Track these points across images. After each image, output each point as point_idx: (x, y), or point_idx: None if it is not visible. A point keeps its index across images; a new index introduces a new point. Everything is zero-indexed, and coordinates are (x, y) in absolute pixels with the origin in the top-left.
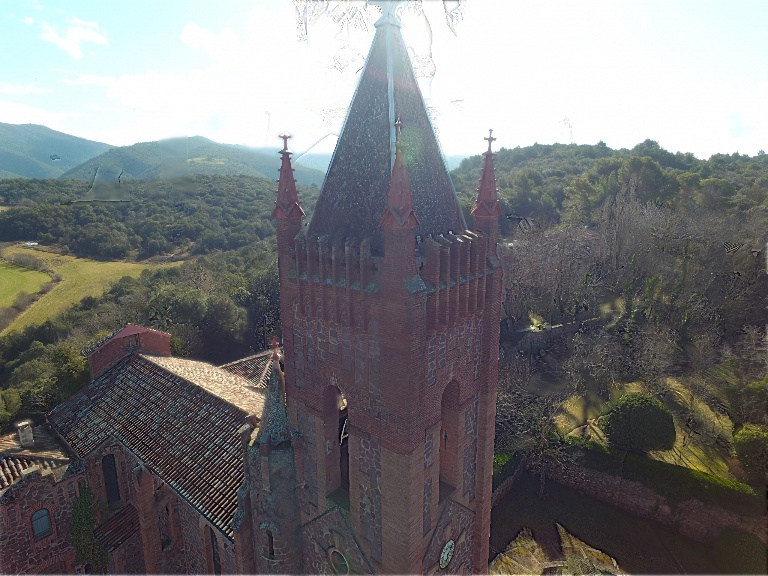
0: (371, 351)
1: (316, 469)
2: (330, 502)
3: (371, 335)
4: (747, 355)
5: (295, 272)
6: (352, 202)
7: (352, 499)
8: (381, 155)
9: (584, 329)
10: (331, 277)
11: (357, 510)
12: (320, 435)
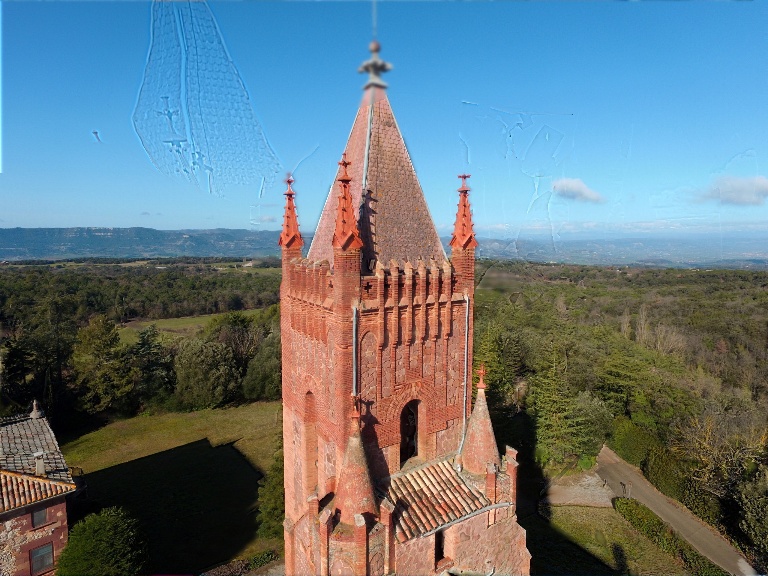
0: None
1: None
2: None
3: None
4: None
5: None
6: None
7: None
8: None
9: None
10: None
11: None
12: None
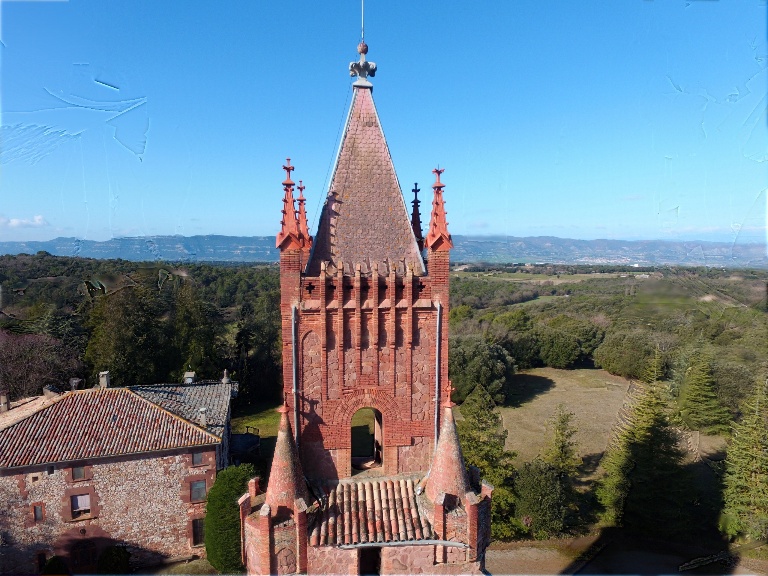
0: None
1: None
2: None
3: None
4: None
5: None
6: None
7: None
8: None
9: None
10: None
11: None
12: None
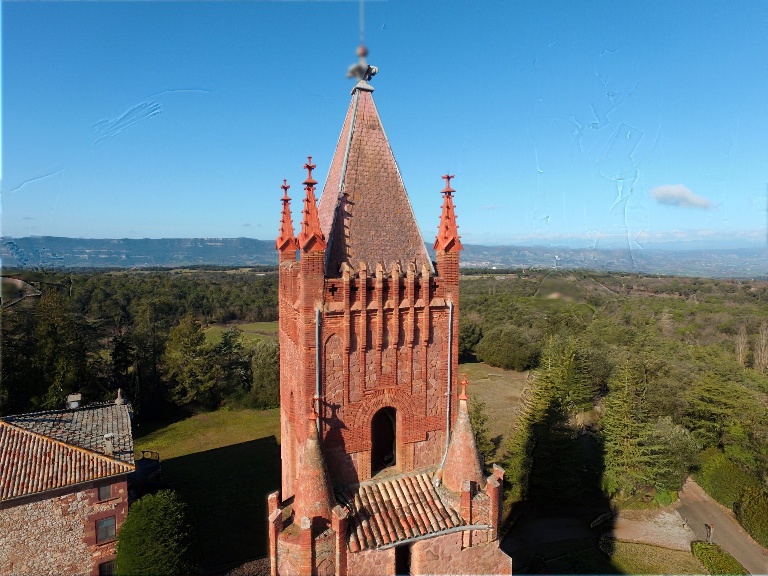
0: None
1: None
2: None
3: None
4: None
5: None
6: None
7: None
8: None
9: None
10: None
11: None
12: None
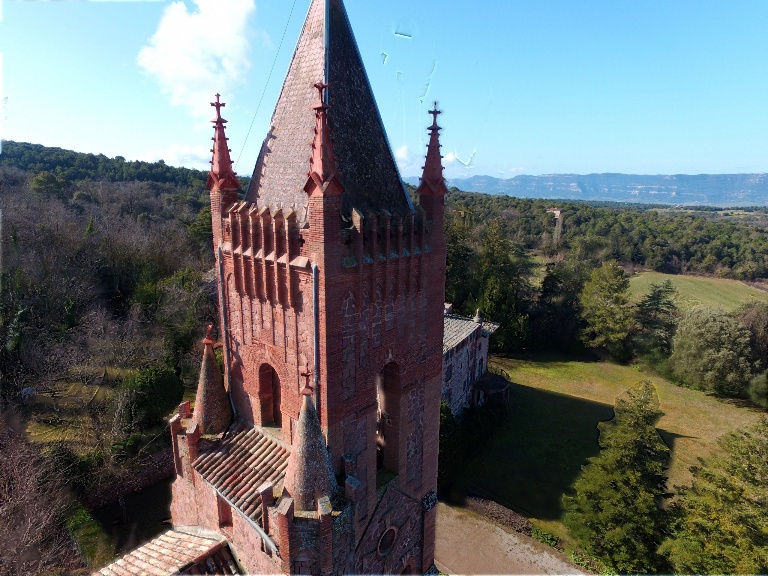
0: (420, 305)
1: (366, 474)
2: (381, 490)
3: (421, 291)
4: (178, 307)
5: (352, 259)
6: (364, 174)
7: (401, 459)
8: (375, 129)
9: (1, 347)
10: (392, 251)
11: (405, 463)
12: (373, 430)
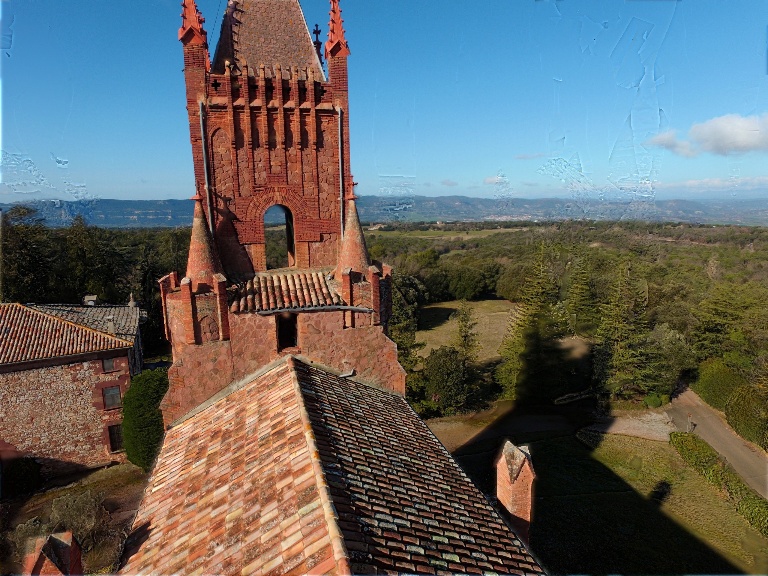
0: None
1: None
2: None
3: None
4: None
5: None
6: None
7: None
8: None
9: None
10: None
11: None
12: None
